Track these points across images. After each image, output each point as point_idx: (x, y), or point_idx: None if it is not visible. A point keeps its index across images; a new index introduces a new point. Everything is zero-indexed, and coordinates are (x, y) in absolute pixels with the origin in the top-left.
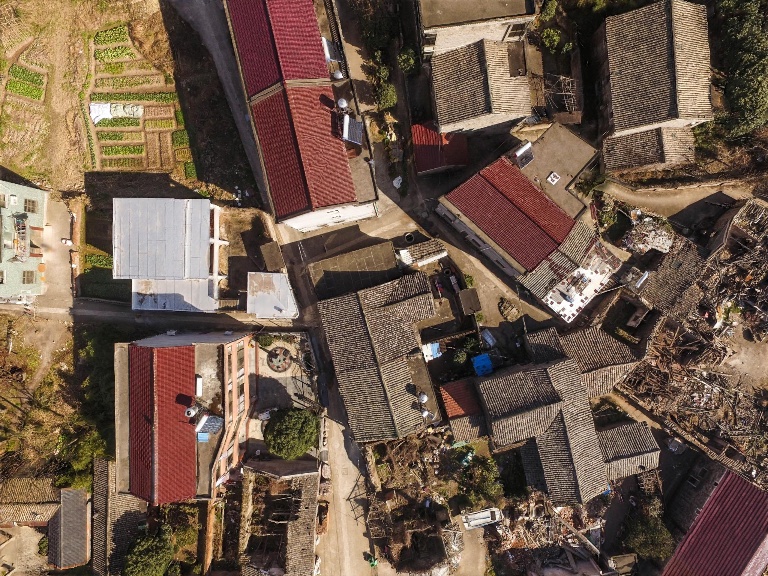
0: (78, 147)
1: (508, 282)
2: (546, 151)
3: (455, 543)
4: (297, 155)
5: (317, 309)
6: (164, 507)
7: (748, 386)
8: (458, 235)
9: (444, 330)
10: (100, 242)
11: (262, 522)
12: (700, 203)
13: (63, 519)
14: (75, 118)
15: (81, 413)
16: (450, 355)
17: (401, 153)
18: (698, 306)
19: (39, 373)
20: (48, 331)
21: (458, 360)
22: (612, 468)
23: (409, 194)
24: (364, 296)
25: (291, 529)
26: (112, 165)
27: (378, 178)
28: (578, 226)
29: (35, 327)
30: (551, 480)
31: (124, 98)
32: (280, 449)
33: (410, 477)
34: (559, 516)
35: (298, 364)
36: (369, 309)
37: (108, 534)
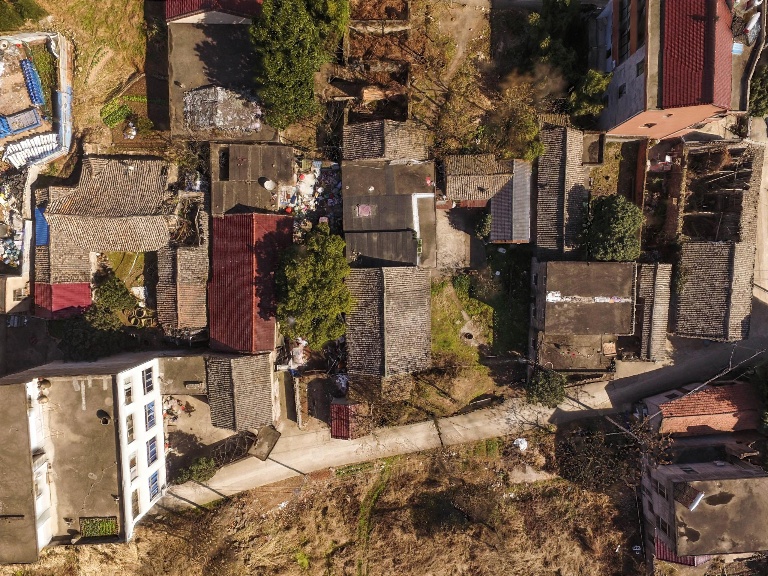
0: None
1: None
2: None
3: None
4: None
5: None
6: (591, 195)
7: None
8: None
9: None
10: None
11: (687, 210)
12: None
13: (514, 191)
14: None
15: (531, 82)
16: None
17: None
18: None
19: (454, 64)
20: (464, 19)
21: None
22: None
23: None
24: None
25: (745, 197)
26: None
27: None
28: None
29: (451, 14)
30: None
31: None
32: None
33: None
34: None
35: None
36: None
37: (565, 202)
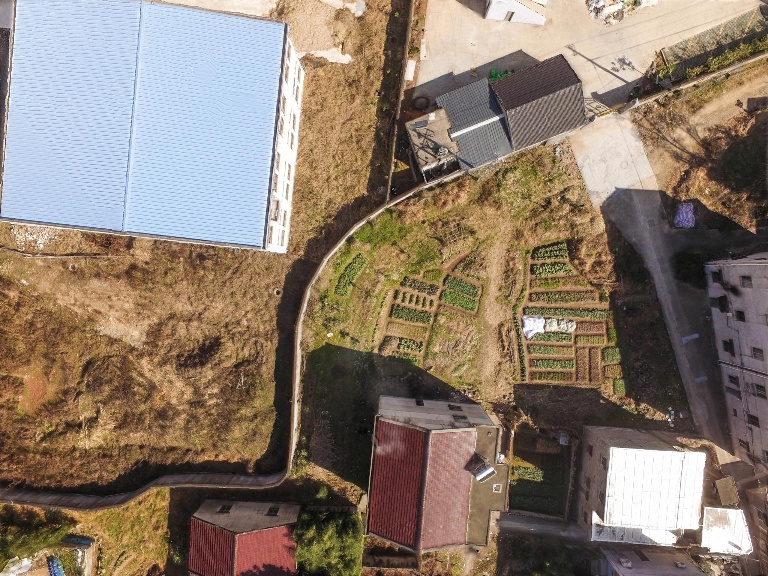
0: (509, 360)
1: None
2: None
3: None
4: None
5: None
6: None
7: None
8: None
9: None
10: (528, 455)
11: None
12: None
13: None
14: (510, 332)
15: None
16: None
17: None
18: None
19: None
20: None
21: None
22: None
23: None
24: None
25: None
26: (542, 378)
27: None
28: None
29: None
30: None
31: (559, 314)
32: None
33: None
34: None
35: None
36: None
37: None
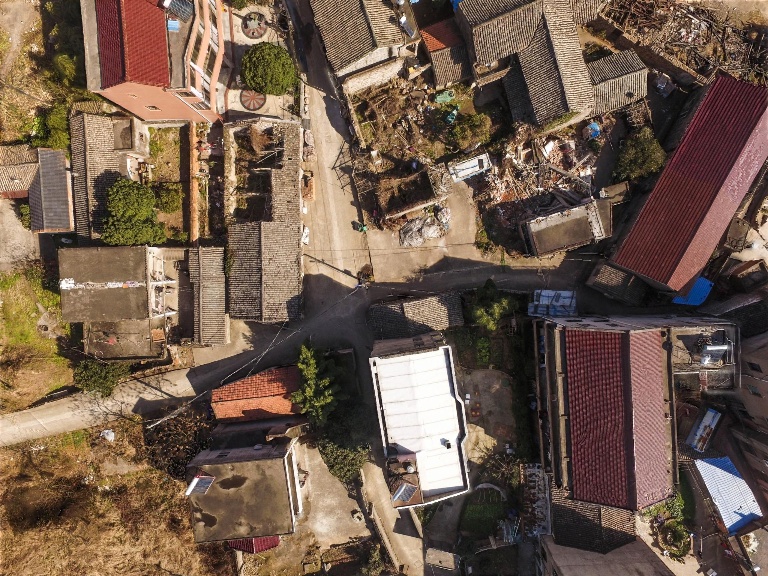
0: None
1: None
2: None
3: (443, 184)
4: None
5: None
6: (146, 181)
7: (737, 21)
8: None
9: None
10: None
11: None
12: None
13: (42, 180)
14: None
15: (53, 71)
16: (429, 8)
17: None
18: None
19: (9, 57)
20: (15, 12)
21: None
22: (599, 96)
23: None
24: None
25: (275, 176)
26: None
27: None
28: None
29: (1, 8)
30: (537, 98)
31: None
32: (256, 67)
33: (395, 139)
34: (548, 162)
35: (274, 29)
36: None
37: (89, 188)
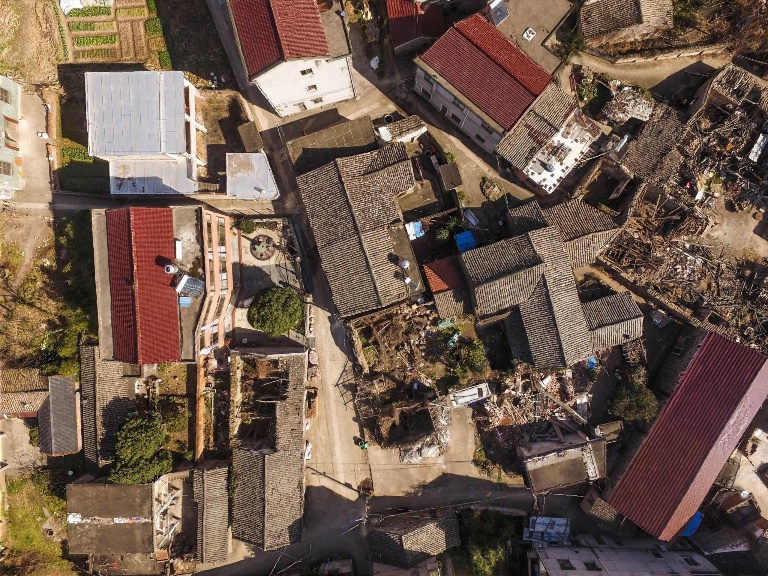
0: (49, 39)
1: (489, 161)
2: (521, 7)
3: (443, 417)
4: (267, 5)
5: (298, 194)
6: (153, 397)
7: (731, 257)
8: (438, 115)
9: (427, 212)
10: (77, 135)
11: (252, 409)
12: (680, 74)
13: (52, 407)
14: (45, 8)
15: (65, 301)
16: (433, 237)
17: (377, 32)
18: (679, 170)
19: (22, 270)
20: (29, 227)
21: (441, 237)
22: (596, 337)
23: (387, 75)
24: (343, 164)
25: (279, 408)
26: (85, 56)
27: (355, 59)
28: (557, 93)
29: (15, 224)
30: (536, 347)
31: None
32: (264, 321)
33: (397, 360)
34: (546, 391)
35: (281, 251)
36: (348, 177)
37: (97, 418)
